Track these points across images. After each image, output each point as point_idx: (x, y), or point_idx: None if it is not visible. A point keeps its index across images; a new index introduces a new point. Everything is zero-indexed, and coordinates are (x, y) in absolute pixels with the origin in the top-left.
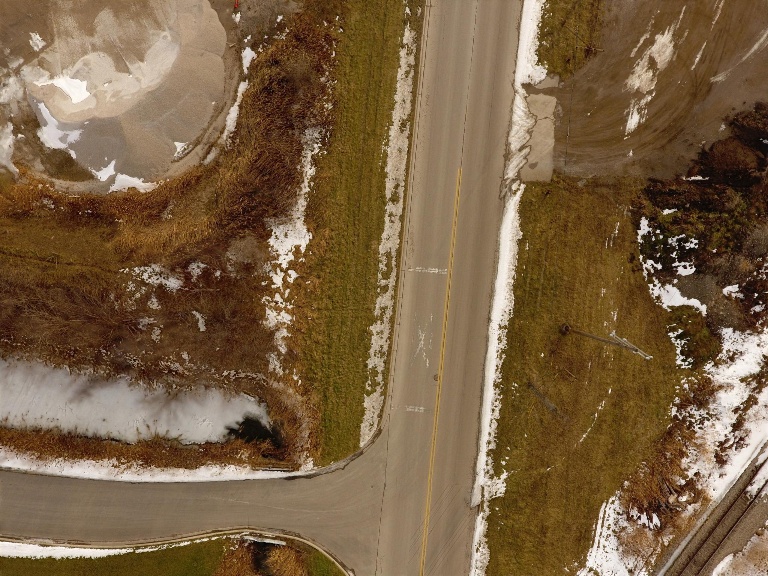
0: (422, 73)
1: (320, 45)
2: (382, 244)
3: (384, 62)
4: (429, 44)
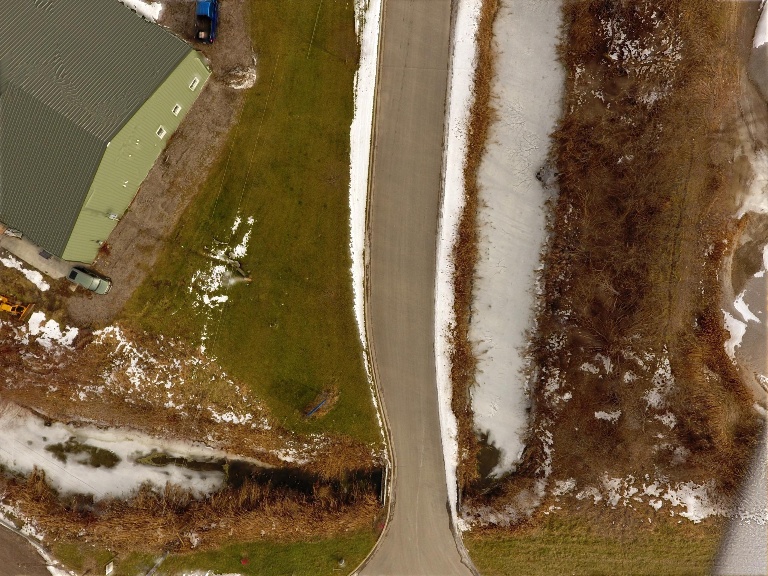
0: None
1: None
2: None
3: None
4: None
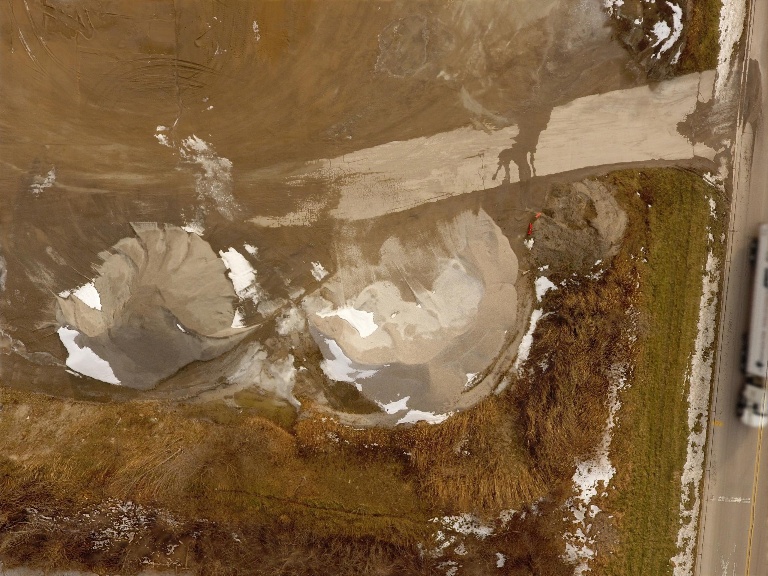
0: (725, 300)
1: (627, 279)
2: (685, 475)
3: (687, 290)
4: (731, 270)
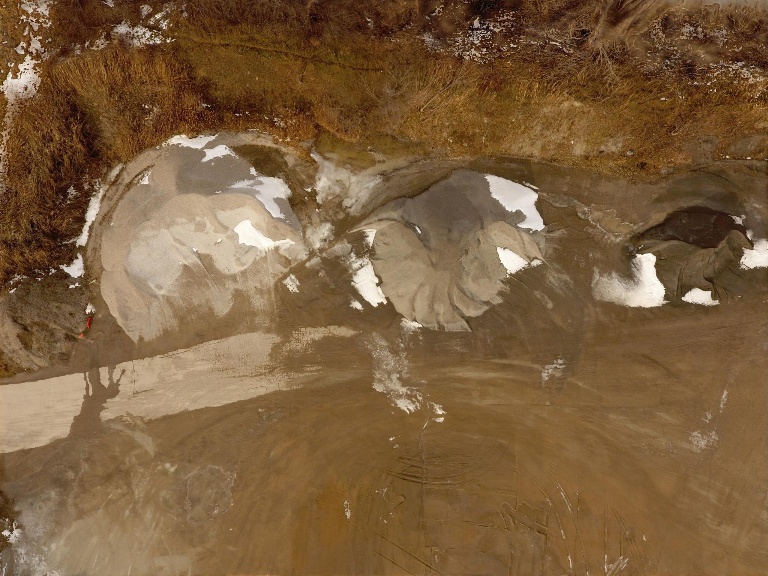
0: None
1: None
2: None
3: None
4: None
